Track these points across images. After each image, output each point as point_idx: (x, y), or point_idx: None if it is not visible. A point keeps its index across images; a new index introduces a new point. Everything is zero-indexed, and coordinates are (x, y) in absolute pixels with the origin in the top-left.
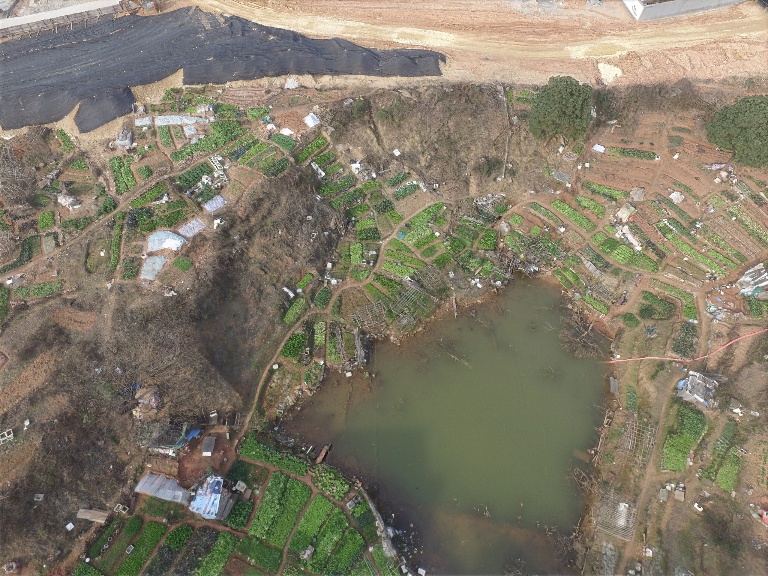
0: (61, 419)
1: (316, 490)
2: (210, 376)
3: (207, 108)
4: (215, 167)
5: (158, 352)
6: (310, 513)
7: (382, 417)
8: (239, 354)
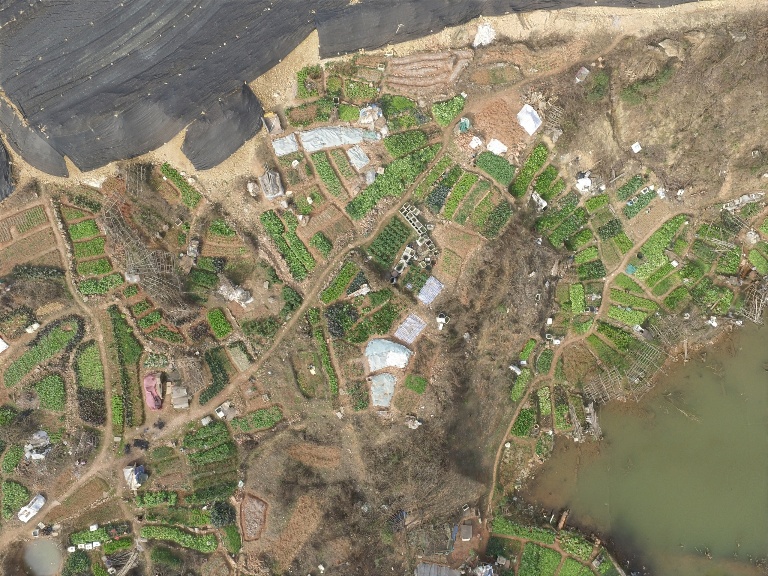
0: (351, 561)
1: (565, 554)
2: (463, 485)
3: (376, 116)
4: (414, 228)
5: (418, 485)
6: (563, 574)
7: (612, 478)
8: (477, 448)
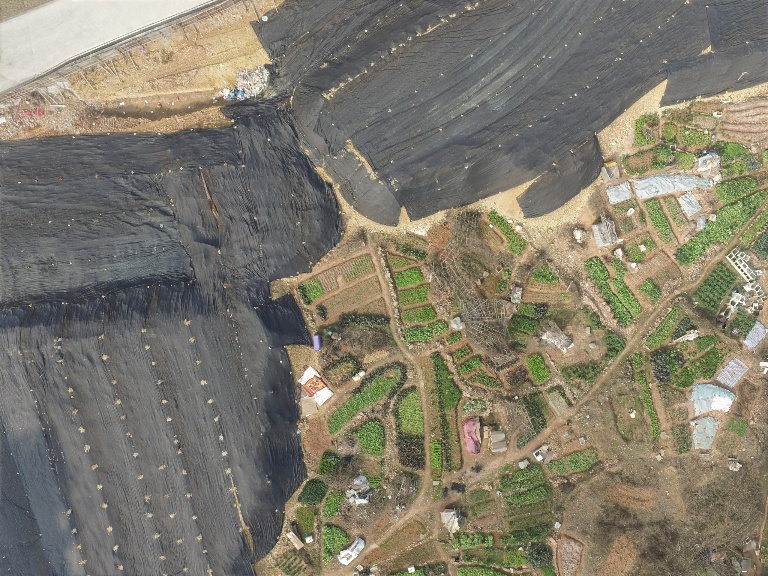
0: None
1: None
2: None
3: (716, 164)
4: (742, 274)
5: None
6: None
7: None
8: None
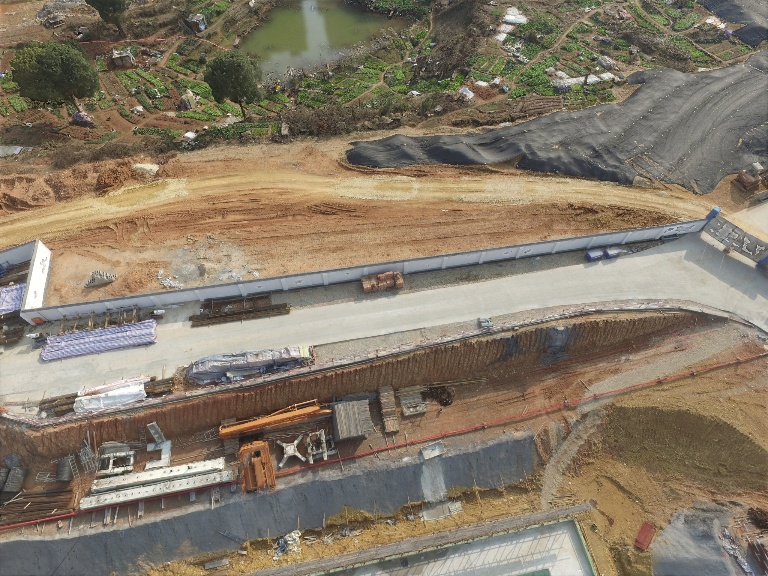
0: None
1: (390, 3)
2: None
3: None
4: None
5: None
6: None
7: (365, 28)
8: None
